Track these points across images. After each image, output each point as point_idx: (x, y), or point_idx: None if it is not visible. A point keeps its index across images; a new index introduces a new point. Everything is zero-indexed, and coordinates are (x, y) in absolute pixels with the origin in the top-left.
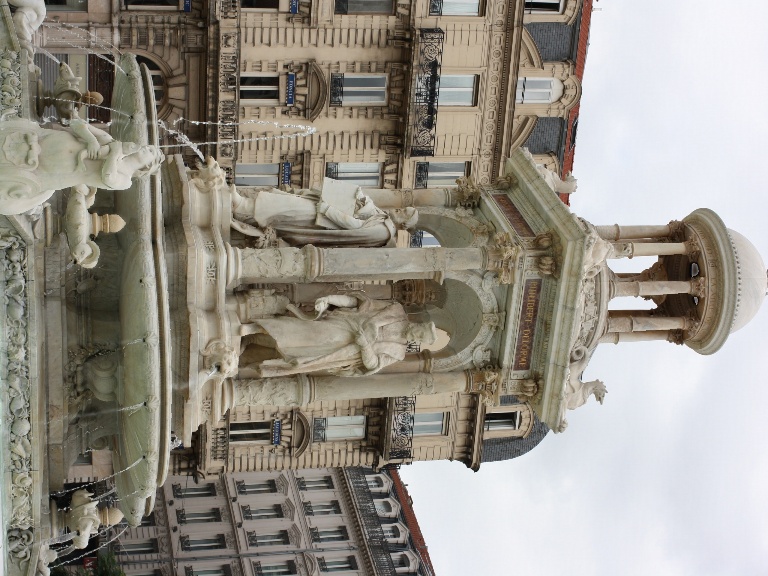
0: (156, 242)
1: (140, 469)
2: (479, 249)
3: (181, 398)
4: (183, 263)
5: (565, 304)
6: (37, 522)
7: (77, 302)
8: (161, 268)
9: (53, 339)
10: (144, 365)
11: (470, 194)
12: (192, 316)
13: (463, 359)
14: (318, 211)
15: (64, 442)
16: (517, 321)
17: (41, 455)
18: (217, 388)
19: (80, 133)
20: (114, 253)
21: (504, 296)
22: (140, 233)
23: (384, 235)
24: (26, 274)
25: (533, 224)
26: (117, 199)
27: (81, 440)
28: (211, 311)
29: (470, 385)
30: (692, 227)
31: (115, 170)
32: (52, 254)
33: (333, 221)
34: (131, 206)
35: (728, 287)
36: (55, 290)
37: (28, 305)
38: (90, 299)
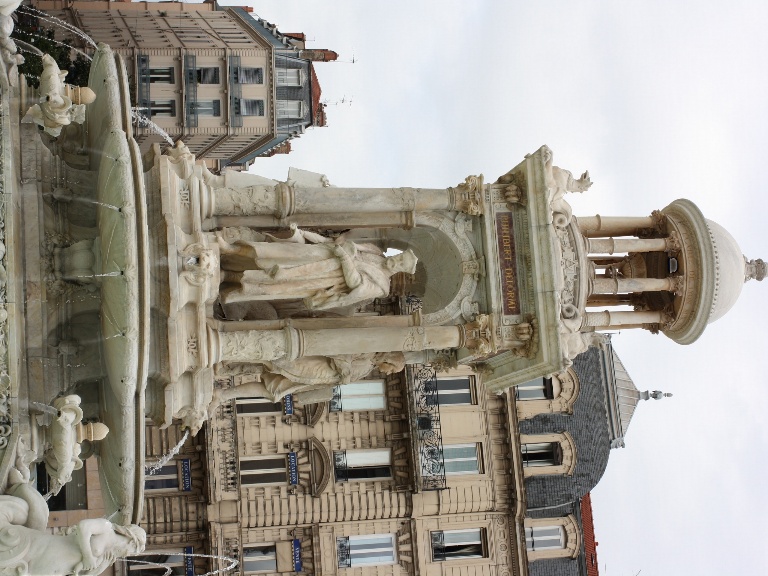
0: None
1: (120, 302)
2: None
3: (164, 328)
4: (156, 178)
5: (538, 224)
6: (14, 395)
7: None
8: None
9: (29, 206)
10: (117, 180)
11: None
12: (167, 214)
13: (452, 314)
14: None
15: (44, 360)
16: (496, 258)
17: None
18: (201, 323)
19: None
20: None
21: (479, 241)
22: (111, 125)
23: None
24: (1, 112)
25: None
26: None
27: (62, 372)
28: None
29: (463, 333)
30: None
31: None
32: (28, 142)
33: None
34: (102, 110)
35: (700, 234)
36: (31, 180)
37: (3, 127)
38: (67, 214)
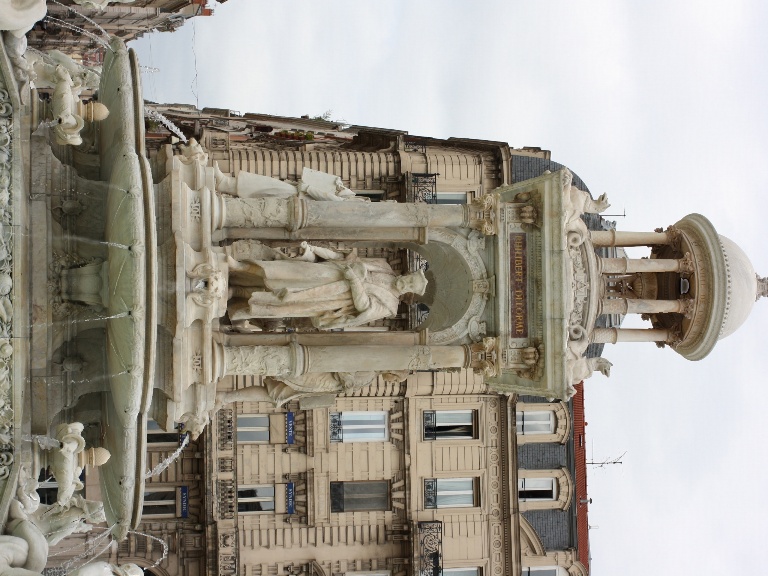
0: (140, 155)
1: (126, 340)
2: None
3: (170, 345)
4: (167, 191)
5: (552, 249)
6: (17, 426)
7: (62, 225)
8: (144, 158)
9: (38, 228)
10: (128, 214)
11: None
12: (177, 233)
13: (459, 333)
14: (299, 190)
15: (48, 379)
16: (507, 280)
17: (23, 339)
18: (207, 340)
19: None
20: (99, 181)
21: (491, 260)
22: (124, 139)
23: None
24: (12, 134)
25: None
26: (102, 142)
27: (66, 389)
28: None
29: (469, 355)
30: None
31: None
32: (38, 155)
33: (315, 198)
34: (115, 120)
35: (715, 257)
36: (40, 195)
37: (13, 154)
38: (76, 226)
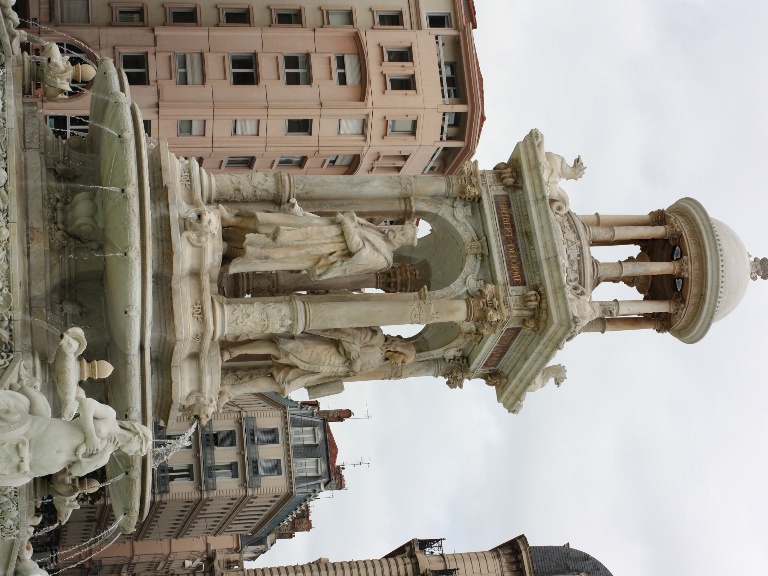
0: None
1: (121, 223)
2: None
3: (168, 291)
4: (157, 159)
5: (535, 198)
6: (16, 318)
7: None
8: None
9: (32, 162)
10: (117, 116)
11: None
12: (168, 182)
13: (458, 291)
14: None
15: (47, 313)
16: (498, 235)
17: (20, 239)
18: (205, 290)
19: None
20: (91, 154)
21: (479, 225)
22: None
23: None
24: (4, 72)
25: None
26: None
27: None
28: None
29: (470, 303)
30: None
31: None
32: (31, 117)
33: None
34: (103, 97)
35: (699, 217)
36: (34, 150)
37: (5, 78)
38: None
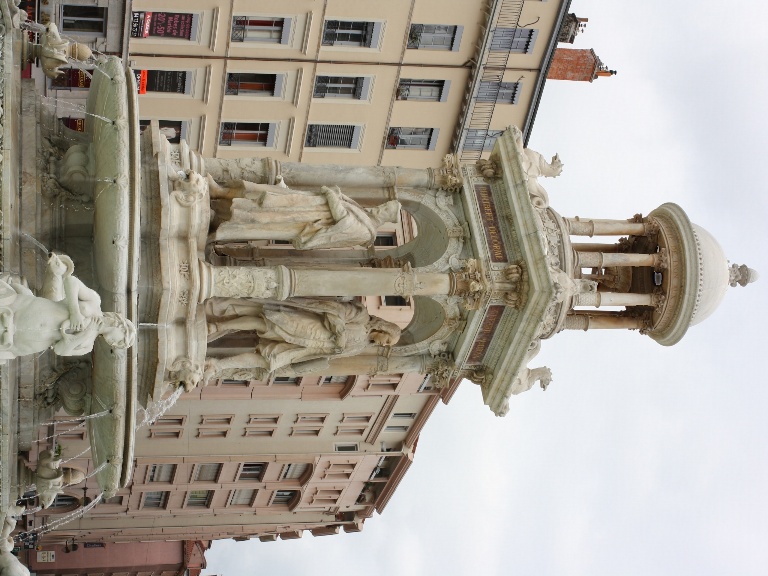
0: None
1: (111, 153)
2: None
3: (156, 248)
4: (148, 137)
5: (515, 184)
6: (6, 237)
7: None
8: None
9: (27, 119)
10: (110, 67)
11: None
12: None
13: (441, 268)
14: None
15: (37, 255)
16: (479, 219)
17: None
18: (193, 251)
19: None
20: None
21: (461, 213)
22: None
23: None
24: None
25: None
26: (87, 126)
27: None
28: None
29: (453, 275)
30: None
31: None
32: (28, 91)
33: None
34: (98, 82)
35: (675, 215)
36: None
37: None
38: None
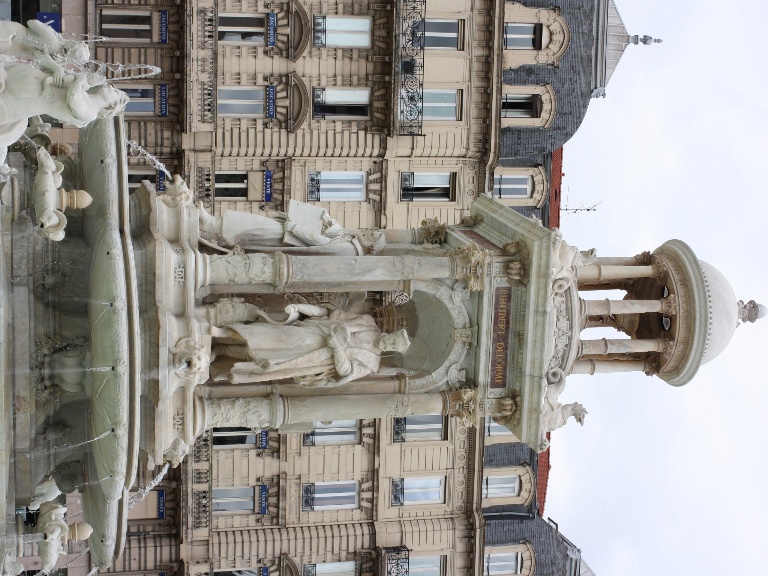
0: (123, 230)
1: (109, 450)
2: (447, 257)
3: (152, 410)
4: (151, 260)
5: (536, 309)
6: (2, 522)
7: (45, 298)
8: (128, 247)
9: (20, 321)
10: (112, 329)
11: (436, 229)
12: (161, 310)
13: (438, 380)
14: (285, 229)
15: (31, 452)
16: (490, 333)
17: (7, 442)
18: (188, 401)
19: (46, 64)
20: (82, 249)
21: (475, 309)
22: (107, 218)
23: (352, 254)
24: None
25: (499, 242)
26: None
27: (49, 455)
28: (180, 316)
29: (447, 405)
30: (658, 255)
31: (80, 92)
32: (19, 238)
33: (301, 239)
34: (98, 194)
35: (698, 302)
36: (22, 277)
37: None
38: (58, 297)
